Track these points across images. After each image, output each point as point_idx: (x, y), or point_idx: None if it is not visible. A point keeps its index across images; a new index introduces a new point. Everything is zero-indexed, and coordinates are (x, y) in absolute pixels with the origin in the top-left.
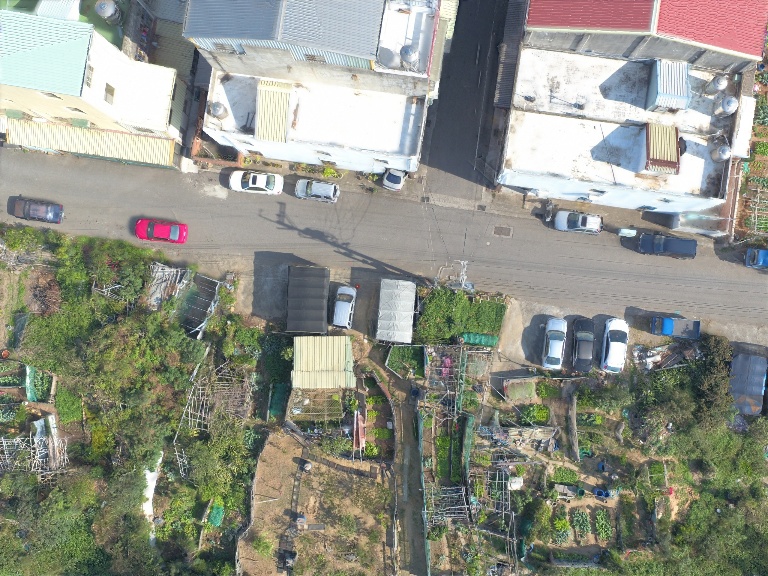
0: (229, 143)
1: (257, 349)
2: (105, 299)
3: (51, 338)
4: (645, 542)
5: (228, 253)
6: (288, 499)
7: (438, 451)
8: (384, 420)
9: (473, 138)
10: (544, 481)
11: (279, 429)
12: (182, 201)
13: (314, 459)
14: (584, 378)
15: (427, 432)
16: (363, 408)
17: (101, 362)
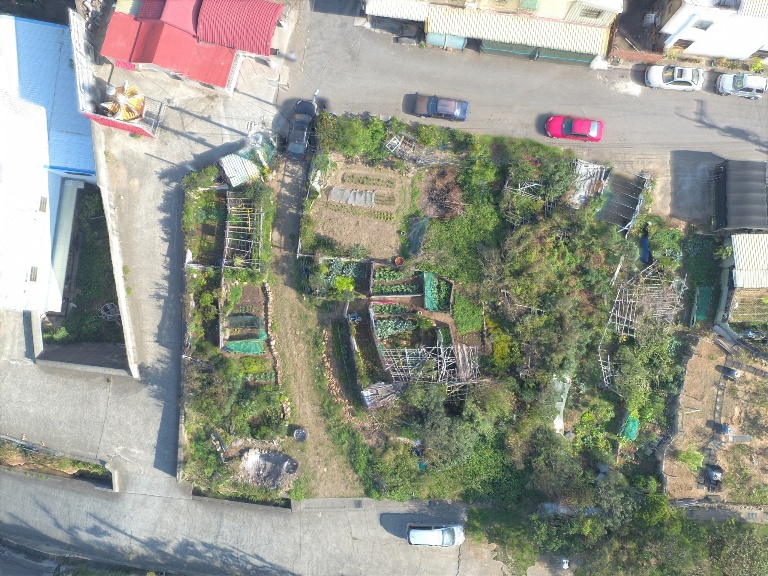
0: (677, 28)
1: (678, 252)
2: None
3: (452, 243)
4: None
5: (642, 152)
6: (710, 410)
7: None
8: None
9: None
10: None
11: (708, 334)
12: (591, 99)
13: (739, 367)
14: None
15: None
16: None
17: (522, 263)
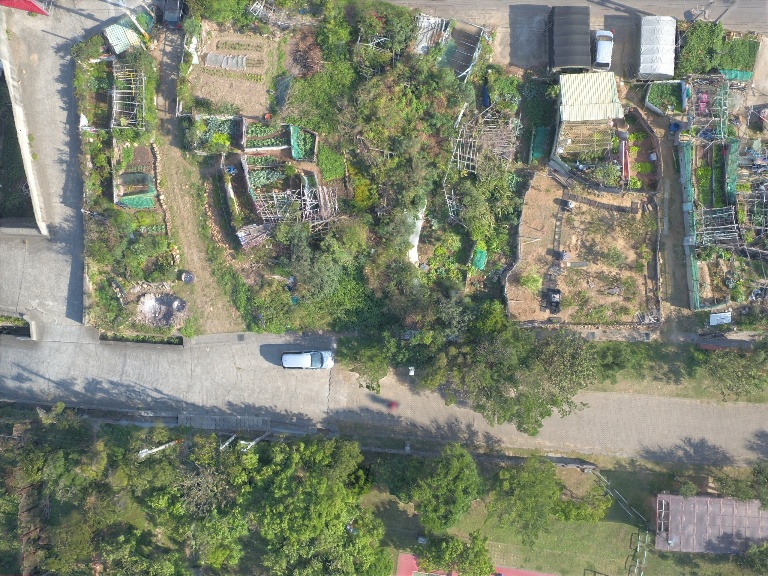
0: None
1: (517, 96)
2: None
3: (314, 98)
4: None
5: (484, 8)
6: (550, 239)
7: (700, 181)
8: (645, 155)
9: None
10: None
11: (543, 168)
12: None
13: (575, 199)
14: None
15: None
16: None
17: (372, 109)
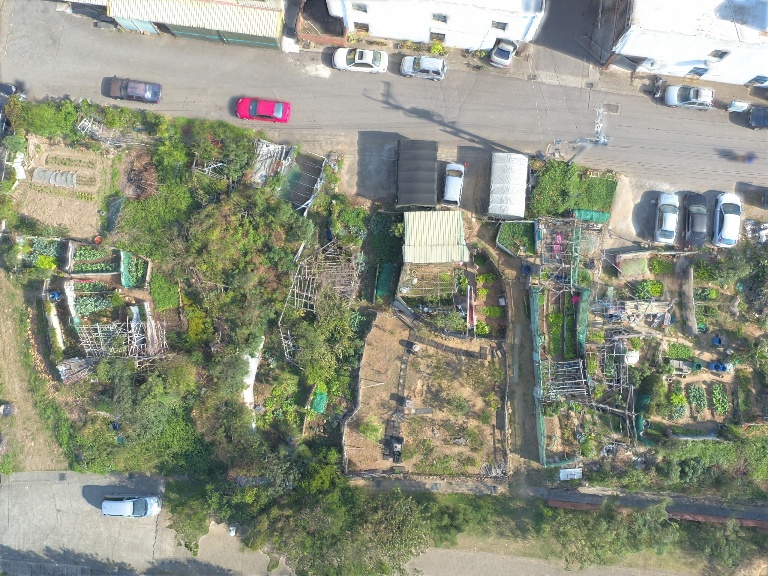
0: (341, 11)
1: (362, 229)
2: (206, 178)
3: (147, 222)
4: (762, 417)
5: (331, 133)
6: (394, 383)
7: (551, 328)
8: (495, 298)
9: (579, 16)
10: (659, 357)
11: (387, 309)
12: (283, 81)
13: (421, 341)
14: (697, 253)
15: (539, 309)
16: (473, 286)
17: (204, 241)
